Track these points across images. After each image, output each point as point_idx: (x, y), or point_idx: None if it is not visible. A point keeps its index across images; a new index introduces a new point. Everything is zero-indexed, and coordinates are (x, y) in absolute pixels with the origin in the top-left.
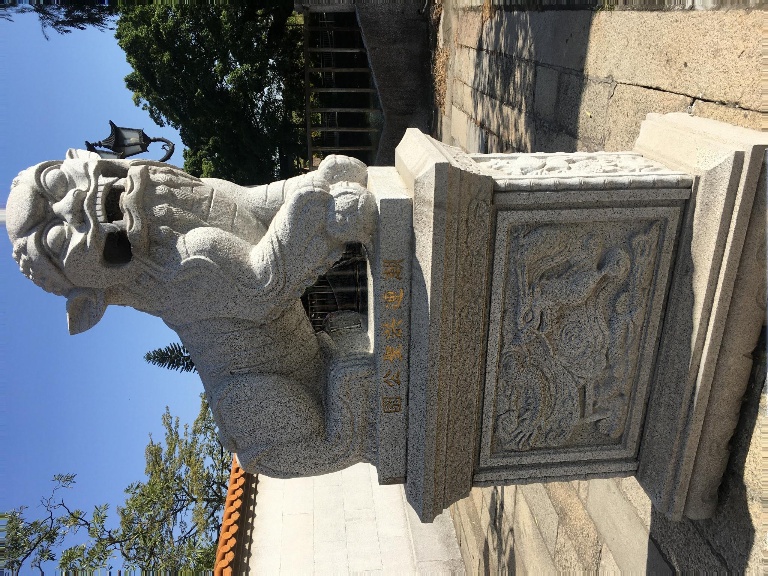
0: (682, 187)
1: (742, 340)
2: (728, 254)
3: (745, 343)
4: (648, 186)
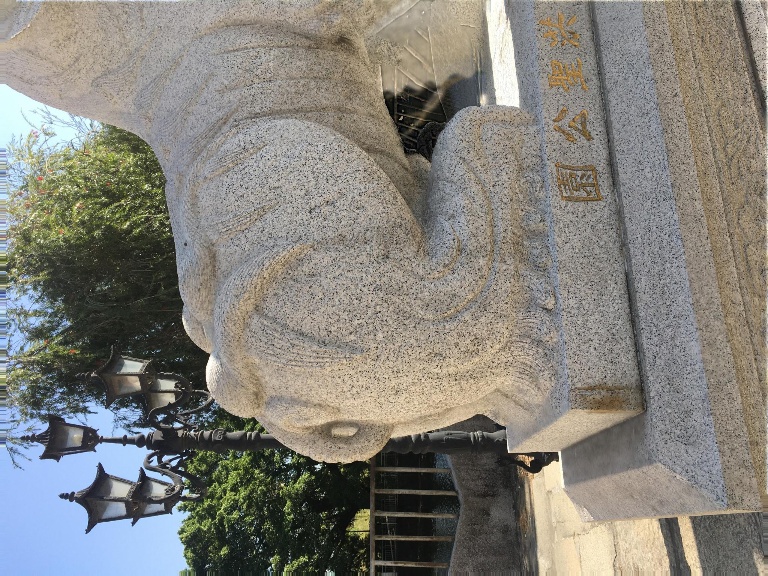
0: None
1: None
2: None
3: None
4: None
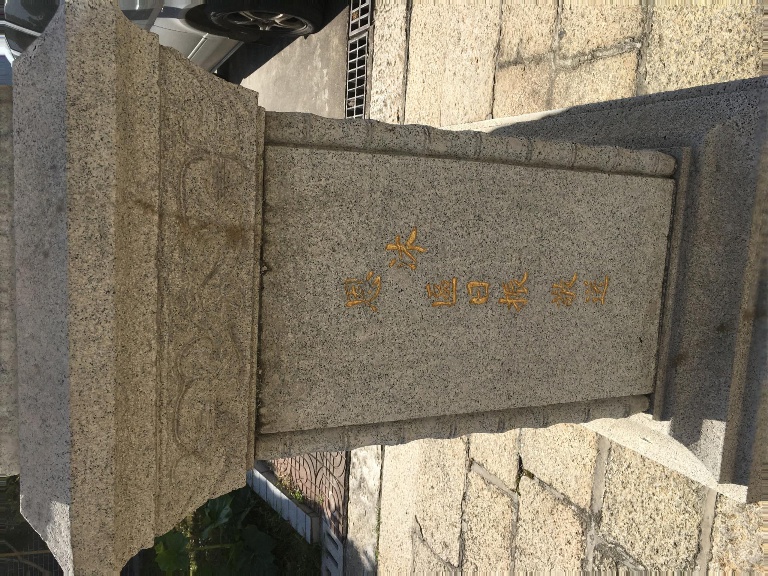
0: None
1: None
2: None
3: None
4: None
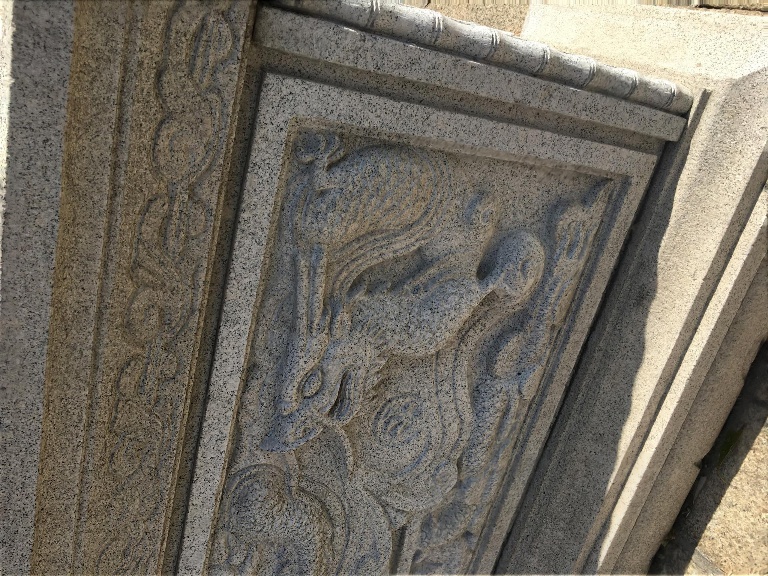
0: (673, 111)
1: (701, 437)
2: (739, 269)
3: (703, 442)
4: (620, 91)
